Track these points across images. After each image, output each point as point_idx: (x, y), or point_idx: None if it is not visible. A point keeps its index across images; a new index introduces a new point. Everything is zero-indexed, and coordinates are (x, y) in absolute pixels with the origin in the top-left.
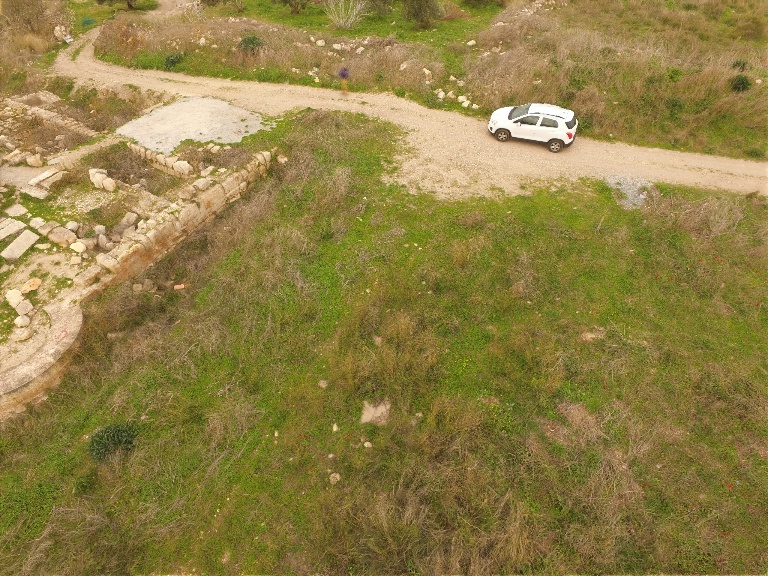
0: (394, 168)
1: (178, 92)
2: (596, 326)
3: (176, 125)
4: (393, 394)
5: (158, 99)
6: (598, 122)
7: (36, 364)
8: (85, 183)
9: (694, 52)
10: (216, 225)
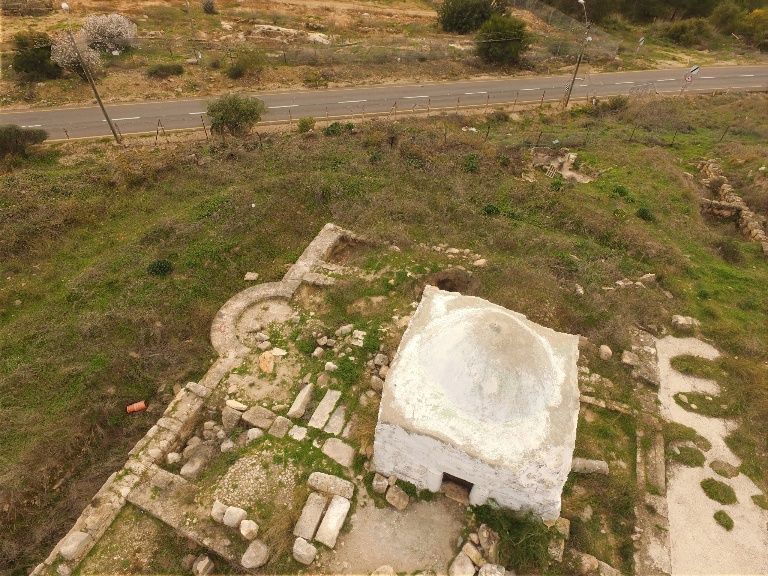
0: None
1: None
2: None
3: None
4: None
5: None
6: None
7: (232, 308)
8: (267, 521)
9: None
10: None
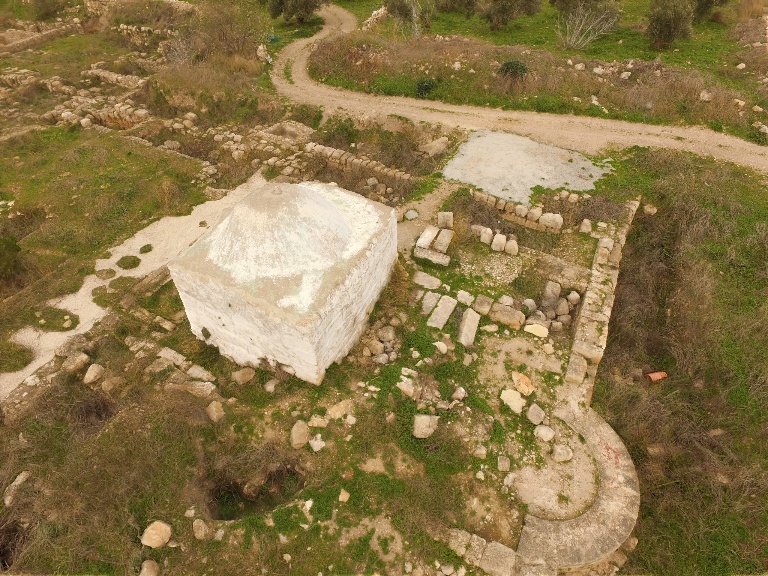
0: None
1: (458, 124)
2: None
3: (504, 167)
4: None
5: (435, 132)
6: None
7: (619, 498)
8: (476, 244)
9: None
10: None
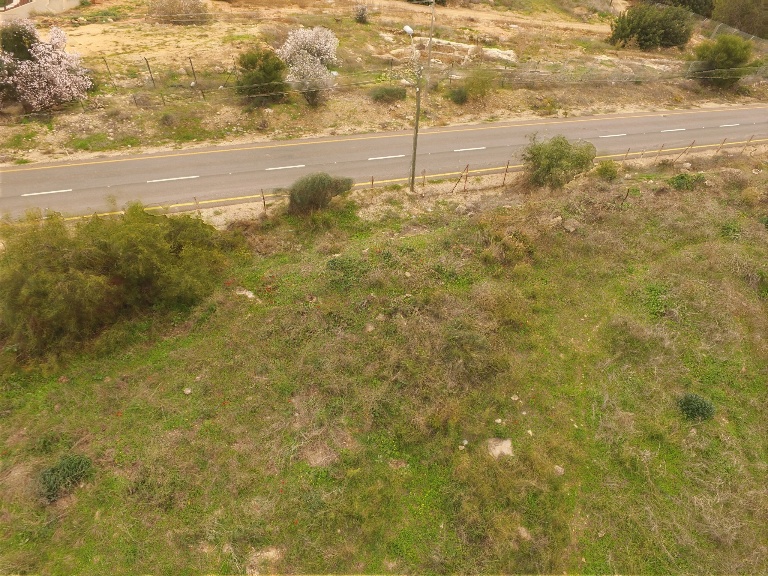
0: None
1: None
2: (254, 575)
3: None
4: None
5: None
6: None
7: None
8: None
9: None
10: None
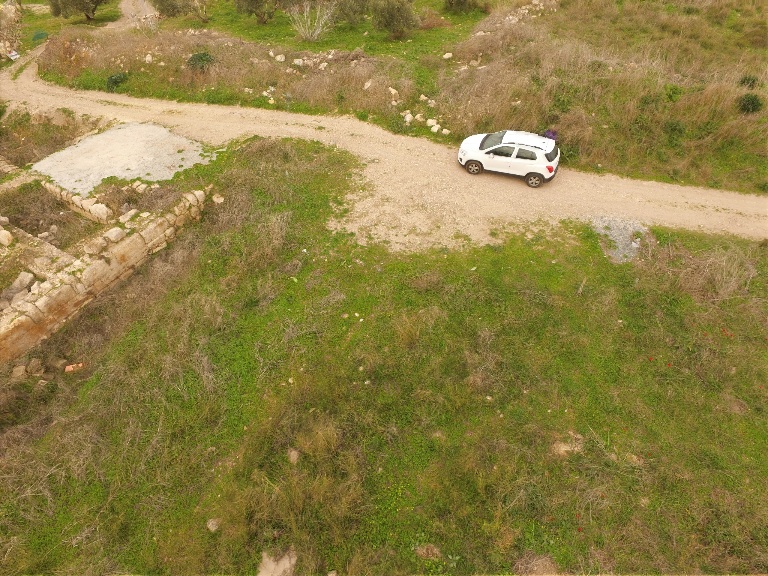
0: (344, 211)
1: (116, 117)
2: (572, 432)
3: (102, 158)
4: (298, 546)
5: (94, 125)
6: (585, 150)
7: None
8: None
9: (696, 63)
10: (132, 282)
